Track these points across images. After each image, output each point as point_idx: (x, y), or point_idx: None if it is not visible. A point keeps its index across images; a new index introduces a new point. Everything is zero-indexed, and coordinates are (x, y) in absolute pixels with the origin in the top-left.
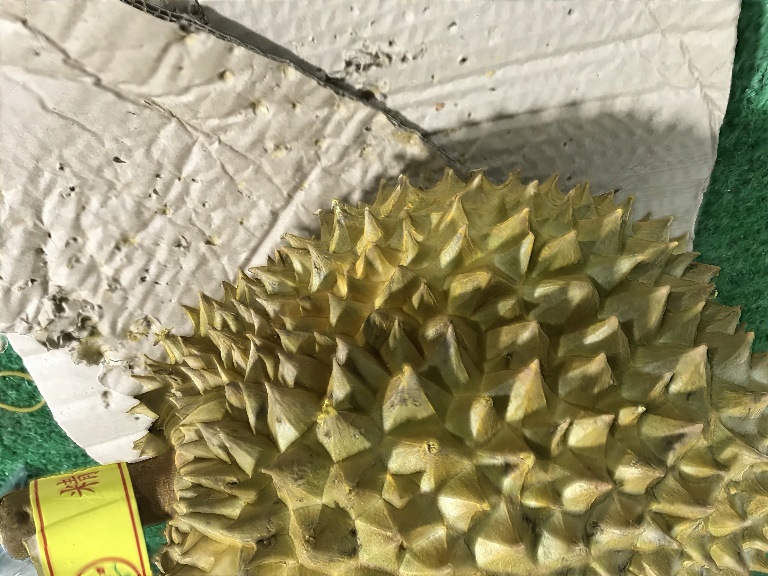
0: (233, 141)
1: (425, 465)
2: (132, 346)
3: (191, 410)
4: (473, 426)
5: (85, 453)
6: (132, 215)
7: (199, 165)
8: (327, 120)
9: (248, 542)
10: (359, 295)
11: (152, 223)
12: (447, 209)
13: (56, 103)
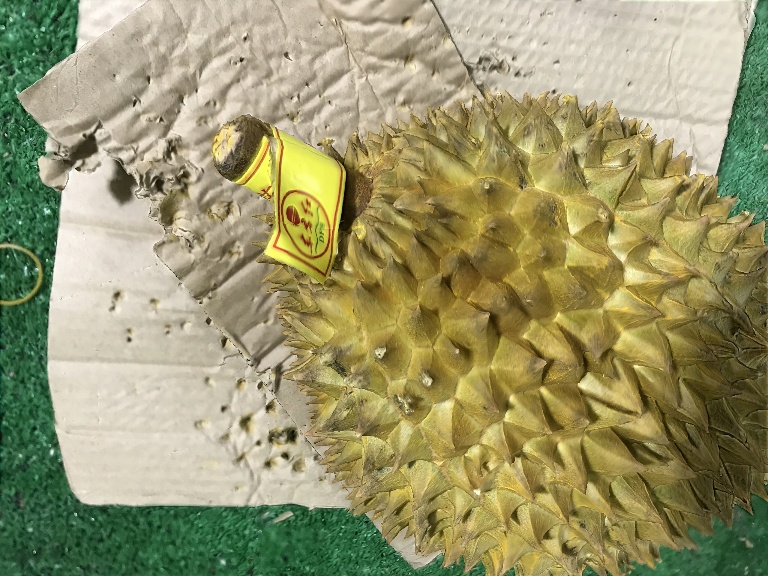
0: (377, 82)
1: (637, 148)
2: (206, 223)
3: None
4: (654, 159)
5: (16, 393)
6: (270, 106)
7: (342, 91)
8: (450, 96)
9: (504, 153)
10: None
11: (279, 123)
12: None
13: None
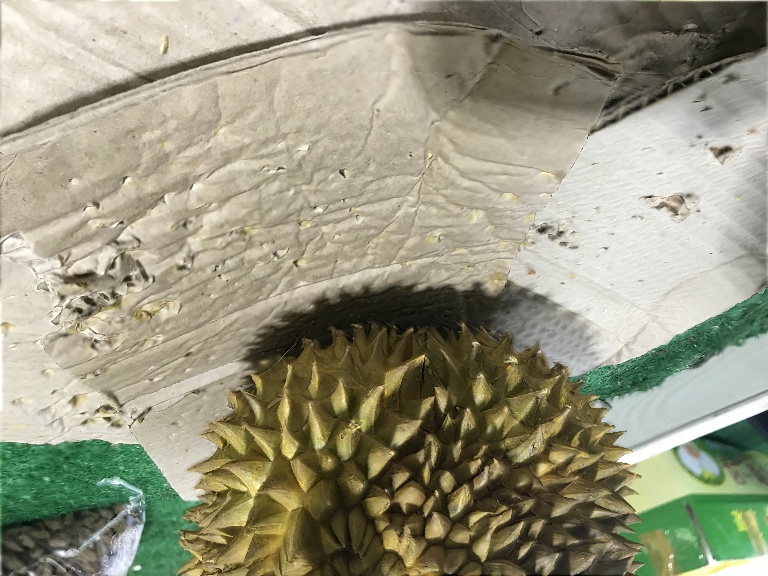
0: (425, 215)
1: None
2: (130, 324)
3: (453, 571)
4: None
5: None
6: (284, 214)
7: (380, 212)
8: (487, 244)
9: None
10: (560, 489)
11: (282, 225)
12: (586, 420)
13: (388, 109)
